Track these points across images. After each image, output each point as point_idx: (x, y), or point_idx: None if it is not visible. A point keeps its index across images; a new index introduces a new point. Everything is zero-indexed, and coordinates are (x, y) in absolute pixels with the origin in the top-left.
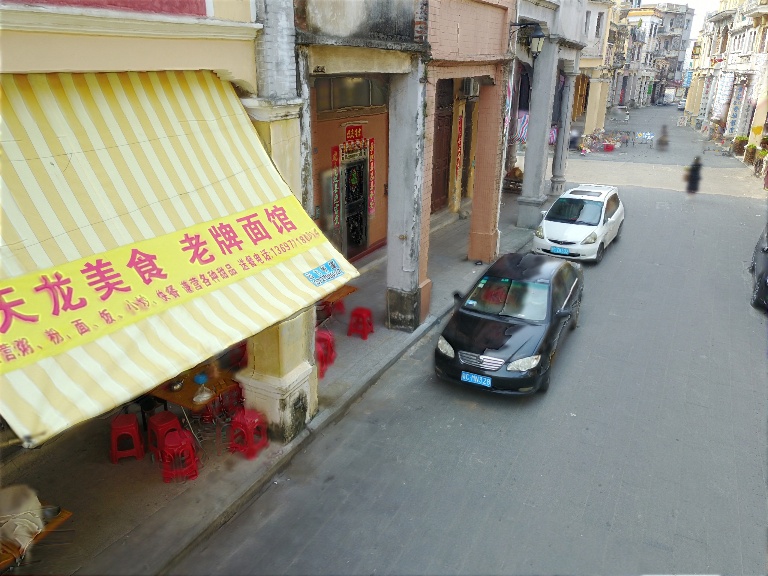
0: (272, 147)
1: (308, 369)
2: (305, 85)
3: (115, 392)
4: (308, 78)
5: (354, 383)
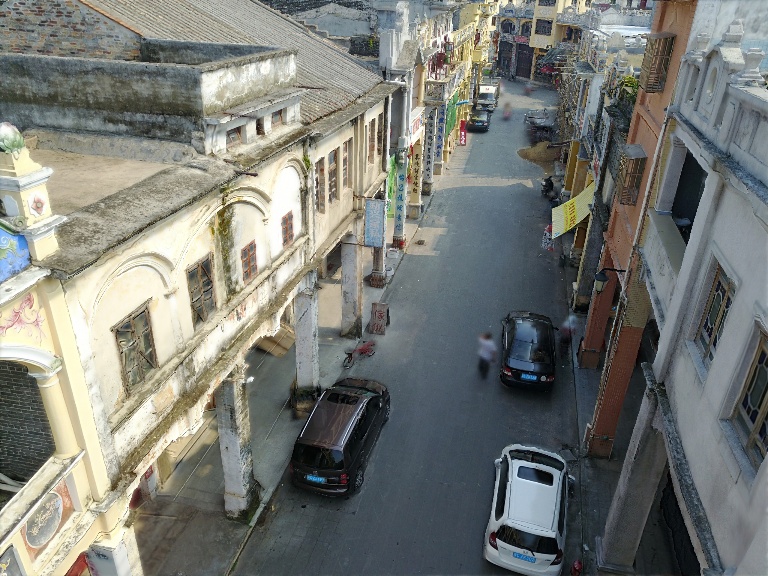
0: None
1: (574, 288)
2: None
3: None
4: (595, 207)
5: (574, 325)
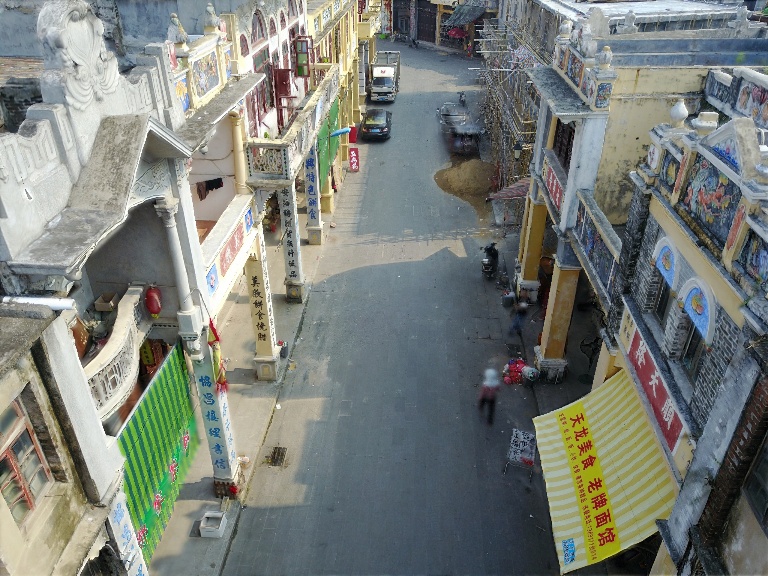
0: (660, 549)
1: None
2: (690, 566)
3: (540, 440)
4: None
5: None
